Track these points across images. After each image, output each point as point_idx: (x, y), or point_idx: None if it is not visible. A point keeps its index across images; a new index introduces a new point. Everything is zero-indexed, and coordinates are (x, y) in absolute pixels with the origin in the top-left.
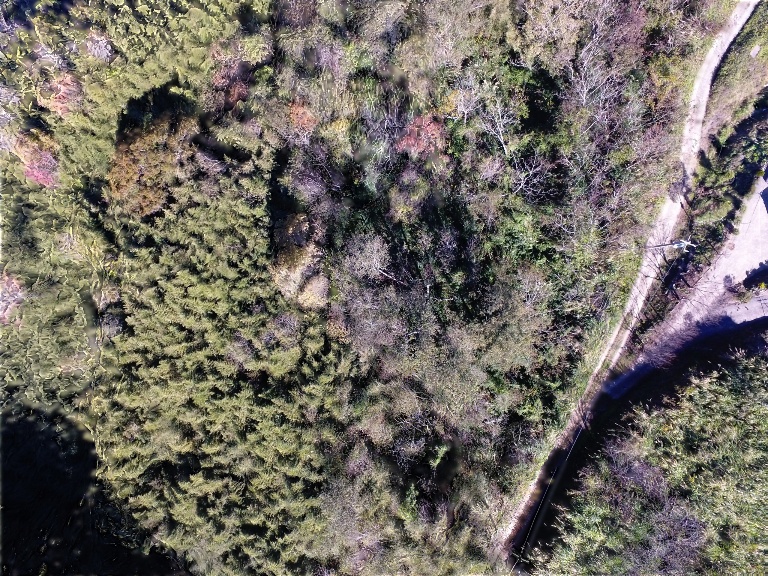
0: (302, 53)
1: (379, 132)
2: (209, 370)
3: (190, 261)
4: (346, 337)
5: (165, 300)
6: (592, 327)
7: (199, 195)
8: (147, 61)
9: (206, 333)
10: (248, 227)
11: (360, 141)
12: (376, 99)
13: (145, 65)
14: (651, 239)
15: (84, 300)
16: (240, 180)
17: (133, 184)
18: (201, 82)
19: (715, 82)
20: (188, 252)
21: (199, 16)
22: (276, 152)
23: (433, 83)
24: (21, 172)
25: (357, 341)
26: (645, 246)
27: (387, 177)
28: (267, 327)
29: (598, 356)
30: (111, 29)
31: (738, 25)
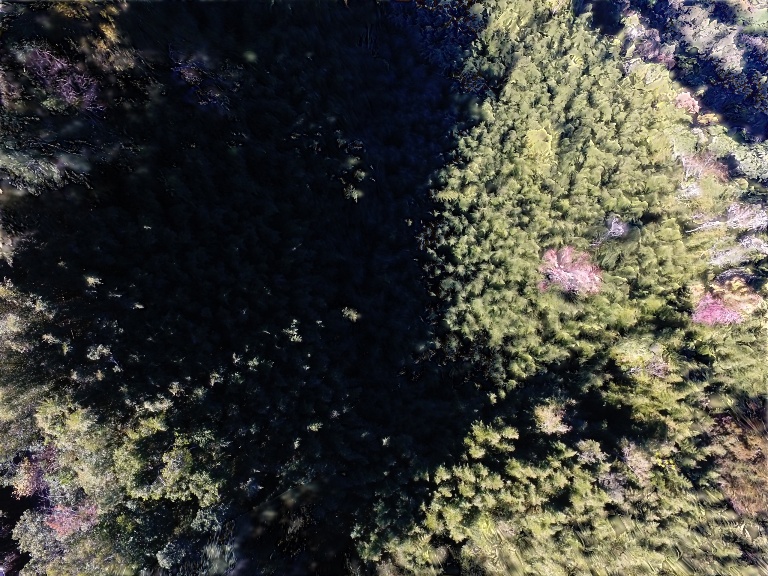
0: None
1: None
2: None
3: None
4: None
5: None
6: None
7: None
8: None
9: None
10: None
11: None
12: None
13: None
14: None
15: (570, 355)
16: None
17: (767, 489)
18: None
19: None
20: None
21: None
22: None
23: None
24: (671, 235)
25: None
26: None
27: None
28: None
29: None
30: None
31: None
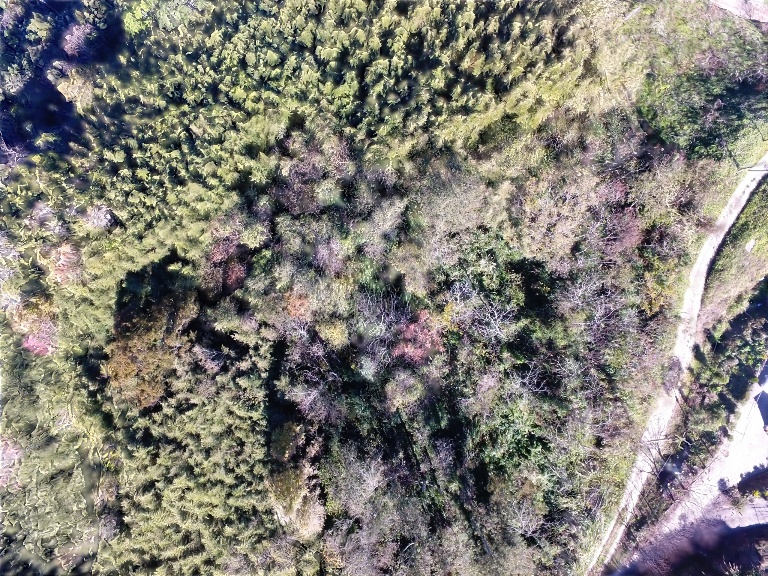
0: (300, 246)
1: (376, 325)
2: (206, 575)
3: (187, 461)
4: (341, 568)
5: (162, 504)
6: (587, 528)
7: (196, 398)
8: (146, 237)
9: (203, 539)
10: (245, 429)
11: (357, 328)
12: (373, 295)
13: (144, 241)
14: (646, 434)
15: (82, 459)
16: (237, 378)
17: (131, 378)
18: (200, 256)
19: (710, 276)
20: (185, 455)
21: (198, 191)
22: (273, 344)
23: (429, 282)
24: None
25: (352, 570)
26: (640, 441)
27: (384, 370)
28: (263, 545)
29: (593, 552)
30: (111, 194)
31: (733, 214)
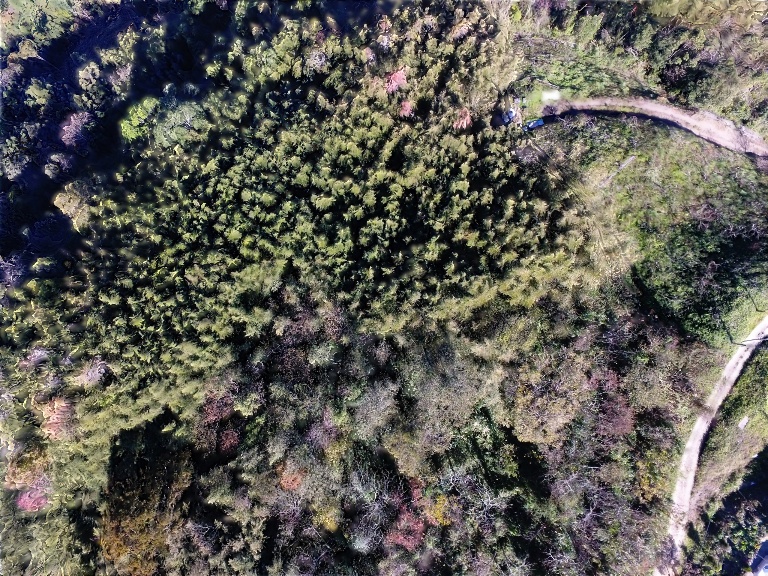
0: (293, 421)
1: (369, 502)
2: None
3: None
4: None
5: None
6: None
7: None
8: (140, 398)
9: None
10: None
11: (350, 500)
12: (366, 475)
13: (138, 401)
14: None
15: None
16: (230, 559)
17: (124, 557)
18: (193, 415)
19: (703, 454)
20: None
21: (192, 351)
22: (266, 519)
23: (422, 464)
24: None
25: None
26: None
27: (376, 547)
28: None
29: None
30: (105, 344)
31: (727, 386)
